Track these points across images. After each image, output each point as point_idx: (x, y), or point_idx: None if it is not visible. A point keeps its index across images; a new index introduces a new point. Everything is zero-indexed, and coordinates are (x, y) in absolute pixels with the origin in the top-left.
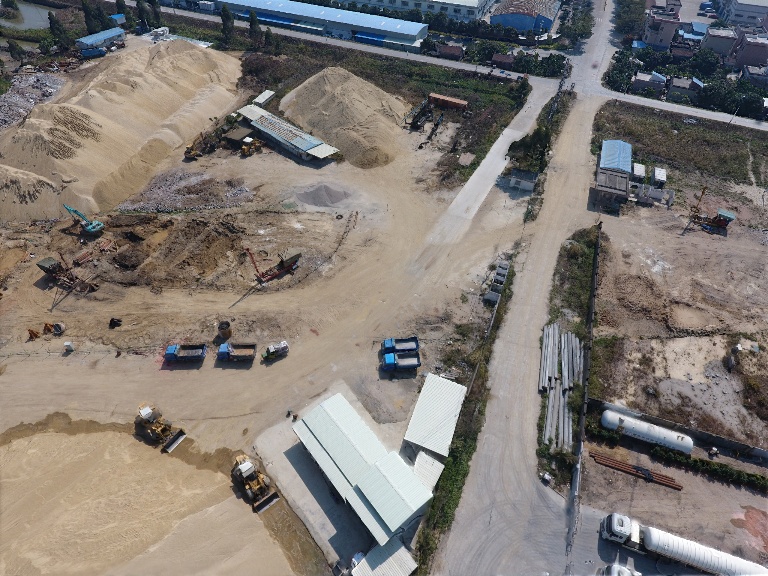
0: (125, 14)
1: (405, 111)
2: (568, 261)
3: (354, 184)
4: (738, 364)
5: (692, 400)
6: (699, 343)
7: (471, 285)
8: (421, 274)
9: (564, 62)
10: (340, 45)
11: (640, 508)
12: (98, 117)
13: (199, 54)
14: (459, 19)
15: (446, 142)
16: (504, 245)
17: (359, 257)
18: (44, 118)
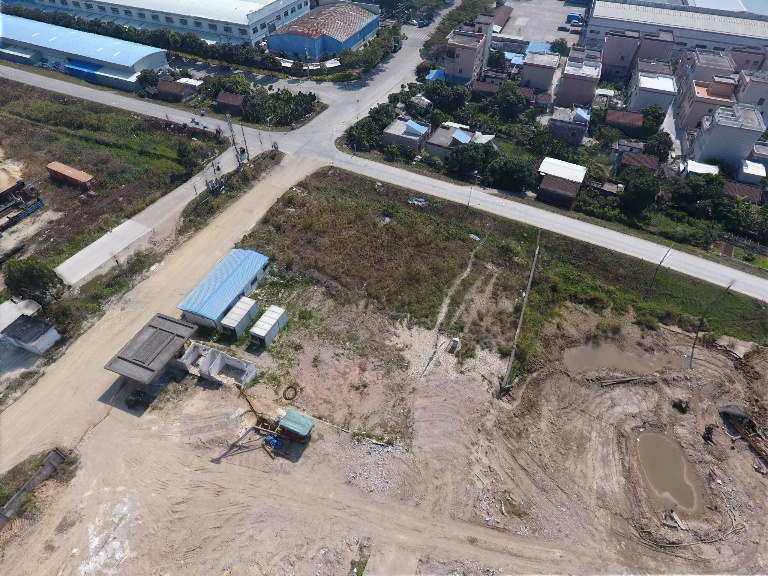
0: None
1: (1, 191)
2: None
3: None
4: None
5: None
6: None
7: None
8: None
9: (323, 102)
10: (23, 81)
11: None
12: None
13: None
14: (223, 41)
15: (3, 250)
16: None
17: None
18: None
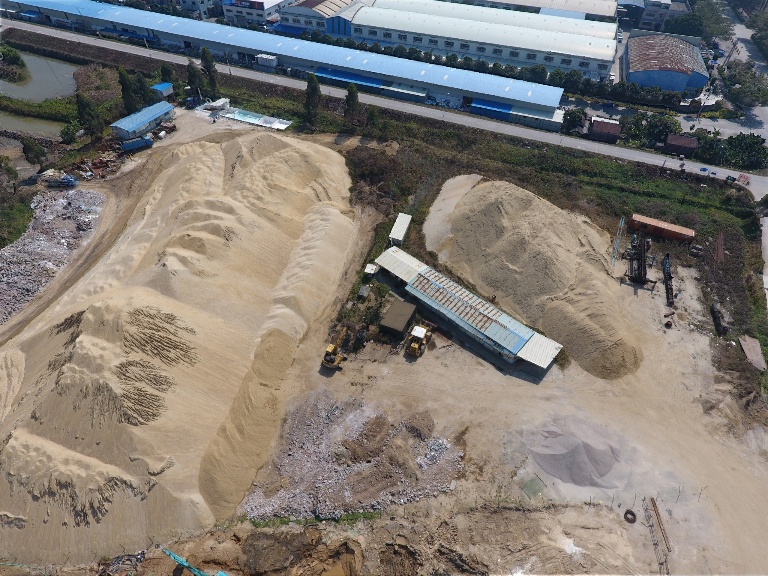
0: (172, 82)
1: (604, 245)
2: None
3: (611, 421)
4: None
5: None
6: None
7: None
8: None
9: None
10: (461, 122)
11: None
12: (187, 312)
13: (296, 157)
14: (591, 77)
15: (698, 311)
16: None
17: None
18: (106, 337)
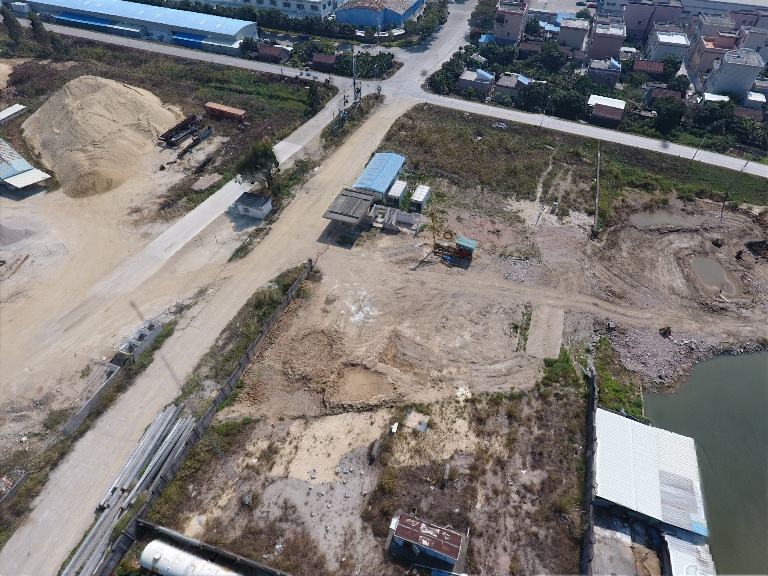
0: None
1: (173, 124)
2: (251, 312)
3: (50, 219)
4: (386, 451)
5: (297, 511)
6: (353, 422)
7: (107, 351)
8: (54, 338)
9: (398, 61)
10: (146, 48)
11: None
12: None
13: None
14: (299, 15)
15: (198, 161)
16: (184, 293)
17: None
18: None
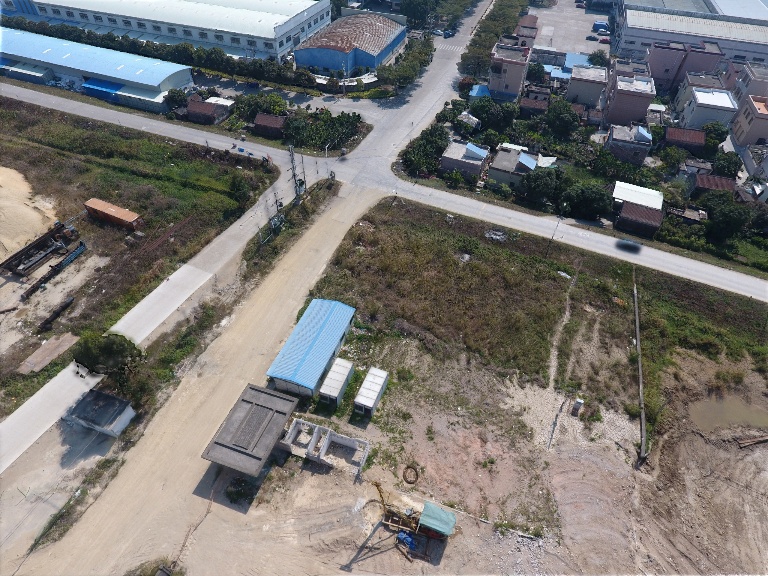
0: None
1: (36, 233)
2: None
3: None
4: None
5: None
6: None
7: None
8: None
9: (366, 121)
10: (40, 103)
11: None
12: None
13: None
14: (249, 56)
15: (50, 306)
16: None
17: None
18: None
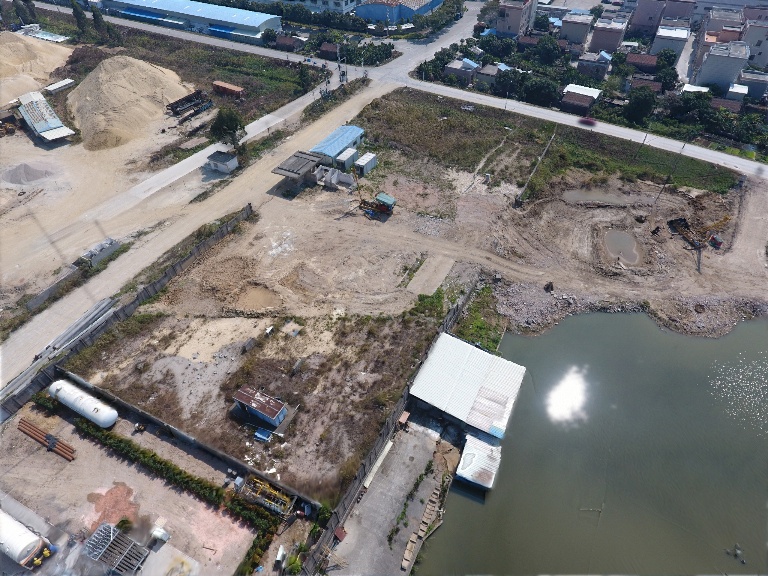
0: (1, 12)
1: None
2: (193, 240)
3: (67, 164)
4: (257, 346)
5: (174, 378)
6: (241, 324)
7: None
8: (42, 247)
9: (399, 51)
10: (183, 37)
11: (14, 474)
12: None
13: (20, 46)
14: (322, 11)
15: (193, 127)
16: (147, 223)
17: (2, 230)
18: None
